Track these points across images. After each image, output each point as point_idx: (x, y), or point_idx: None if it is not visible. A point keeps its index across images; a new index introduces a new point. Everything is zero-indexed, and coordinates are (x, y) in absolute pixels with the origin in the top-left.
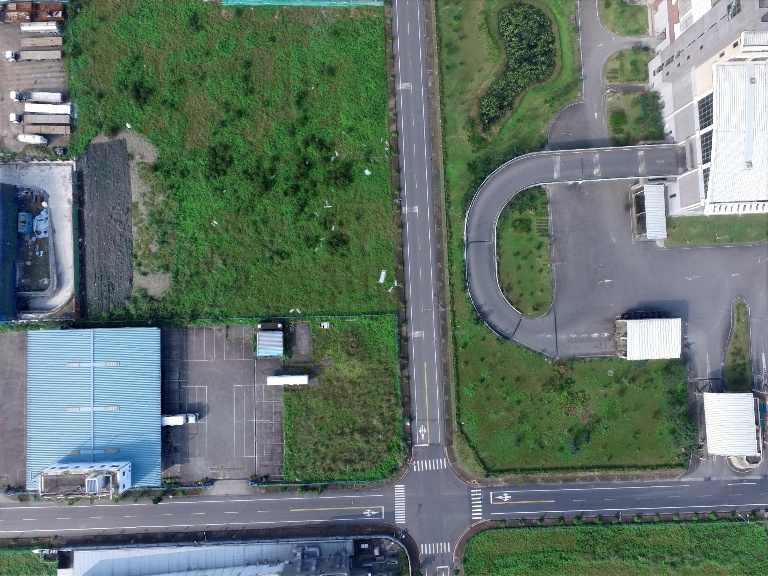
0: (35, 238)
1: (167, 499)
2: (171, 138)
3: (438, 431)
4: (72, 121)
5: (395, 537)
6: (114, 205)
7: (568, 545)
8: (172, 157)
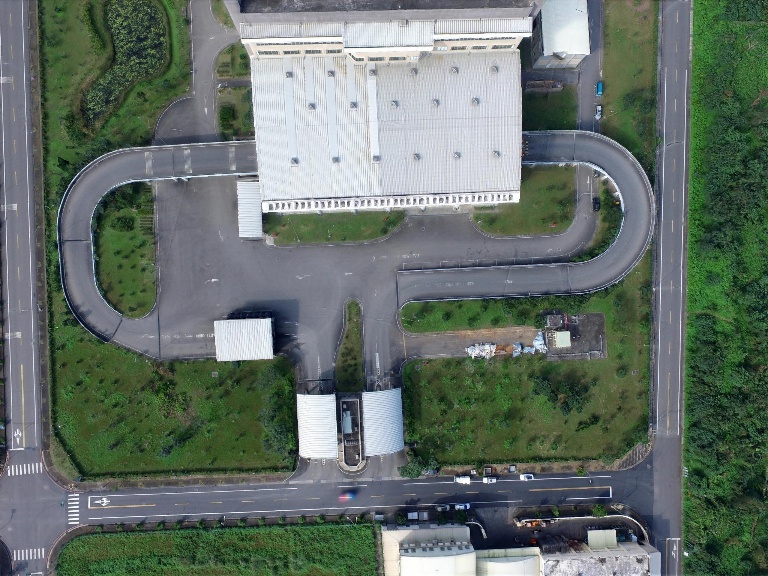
0: None
1: None
2: None
3: (34, 435)
4: None
5: None
6: None
7: (168, 550)
8: None
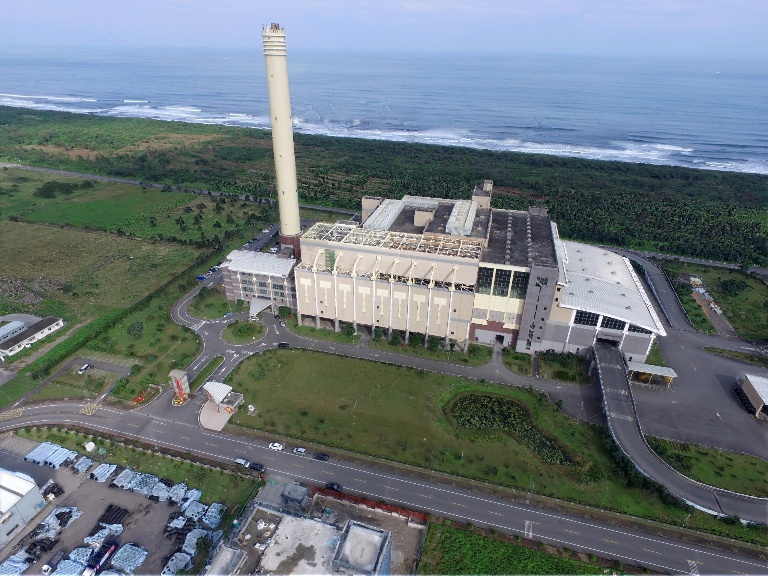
0: None
1: None
2: None
3: None
4: None
5: None
6: None
7: None
8: None
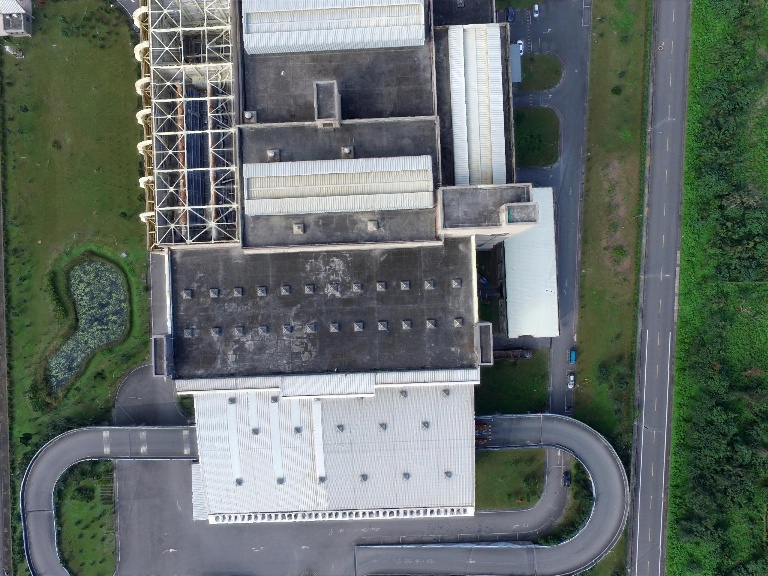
0: None
1: None
2: None
3: None
4: None
5: None
6: None
7: None
8: None
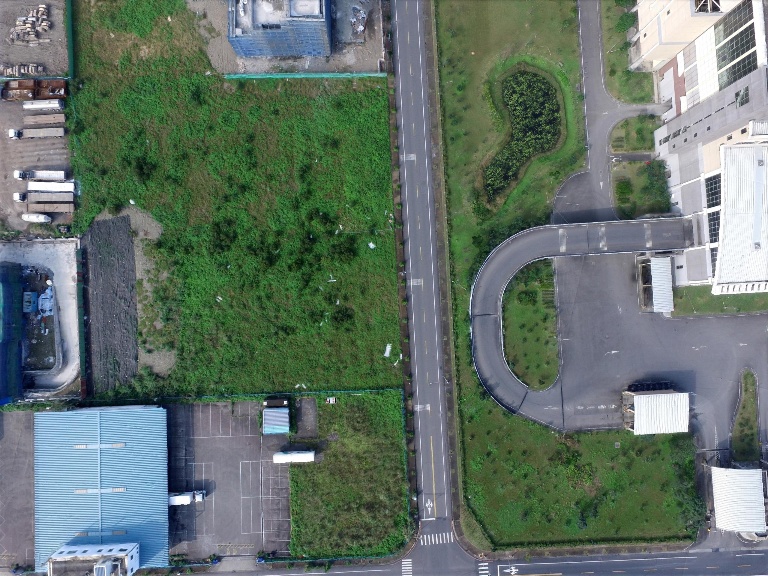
0: (40, 316)
1: (175, 575)
2: (175, 214)
3: (445, 505)
4: (76, 198)
5: None
6: (119, 282)
7: None
8: (176, 233)
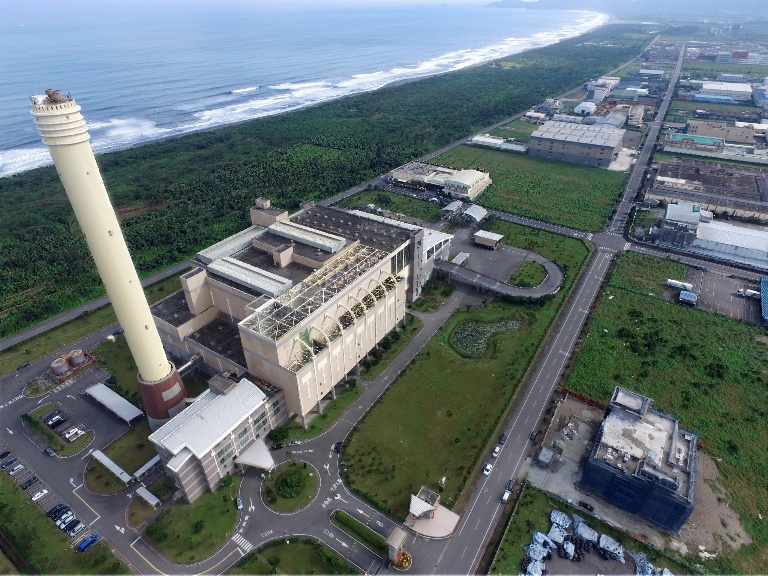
0: None
1: None
2: None
3: None
4: None
5: (633, 241)
6: None
7: None
8: None
